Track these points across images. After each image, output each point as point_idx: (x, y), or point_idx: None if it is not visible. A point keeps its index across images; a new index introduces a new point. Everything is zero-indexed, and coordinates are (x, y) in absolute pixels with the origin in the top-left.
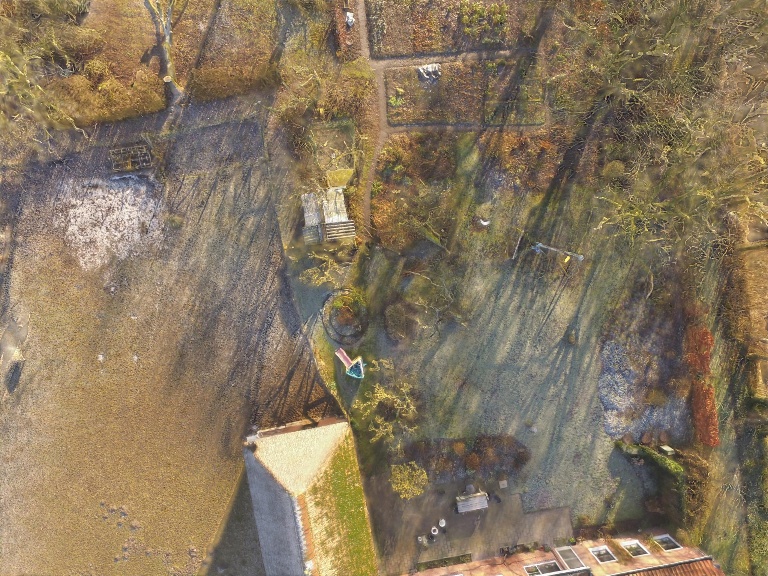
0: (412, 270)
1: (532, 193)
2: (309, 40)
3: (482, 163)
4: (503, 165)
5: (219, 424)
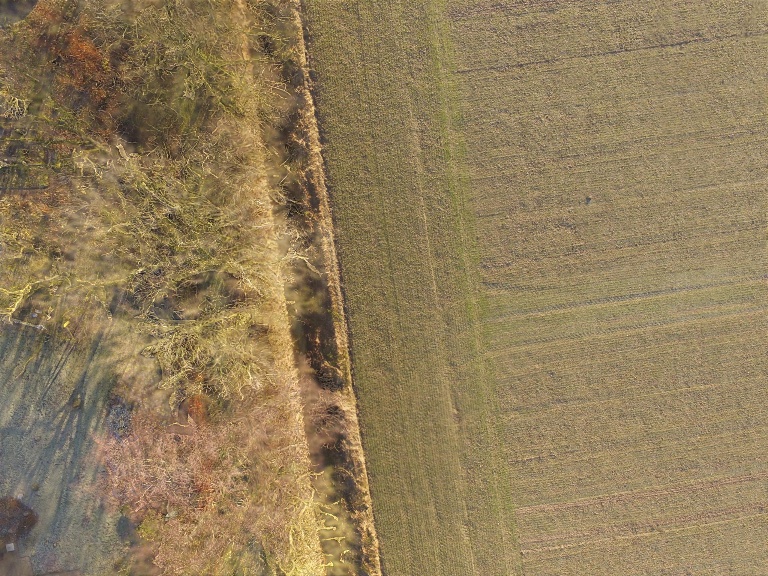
0: None
1: (35, 257)
2: None
3: None
4: (4, 229)
5: None
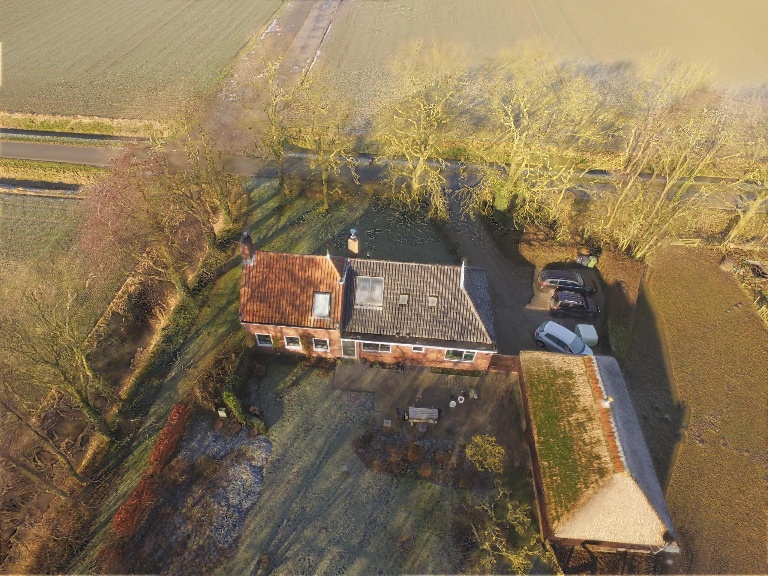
0: None
1: None
2: None
3: None
4: None
5: (699, 575)
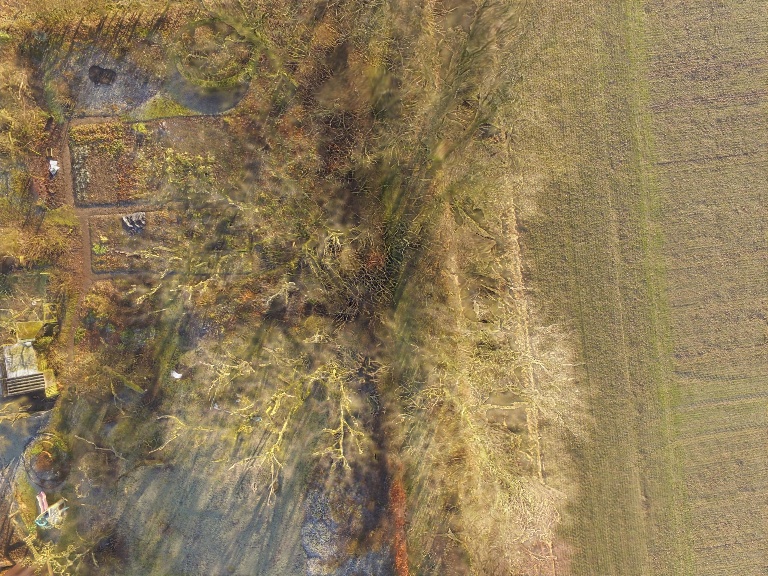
0: (114, 417)
1: (237, 342)
2: (11, 188)
3: (187, 311)
4: None
5: None
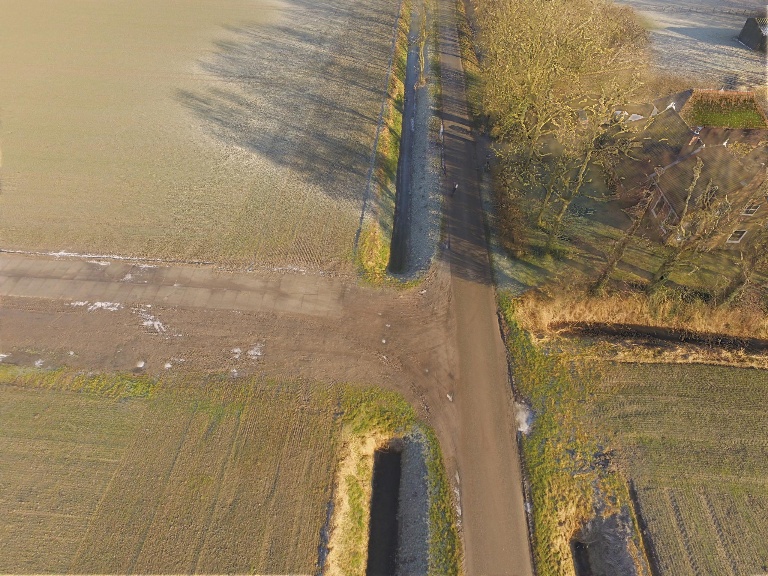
0: None
1: None
2: None
3: None
4: None
5: None
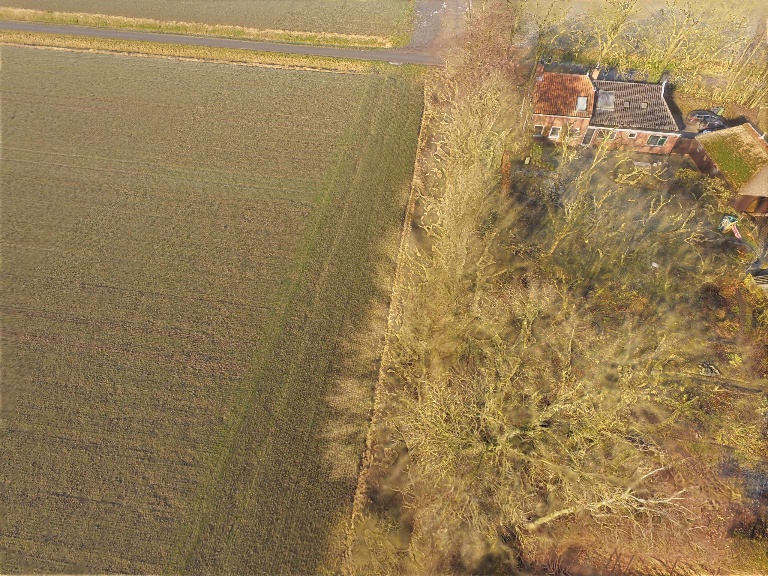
0: (697, 261)
1: None
2: None
3: (653, 304)
4: None
5: None
